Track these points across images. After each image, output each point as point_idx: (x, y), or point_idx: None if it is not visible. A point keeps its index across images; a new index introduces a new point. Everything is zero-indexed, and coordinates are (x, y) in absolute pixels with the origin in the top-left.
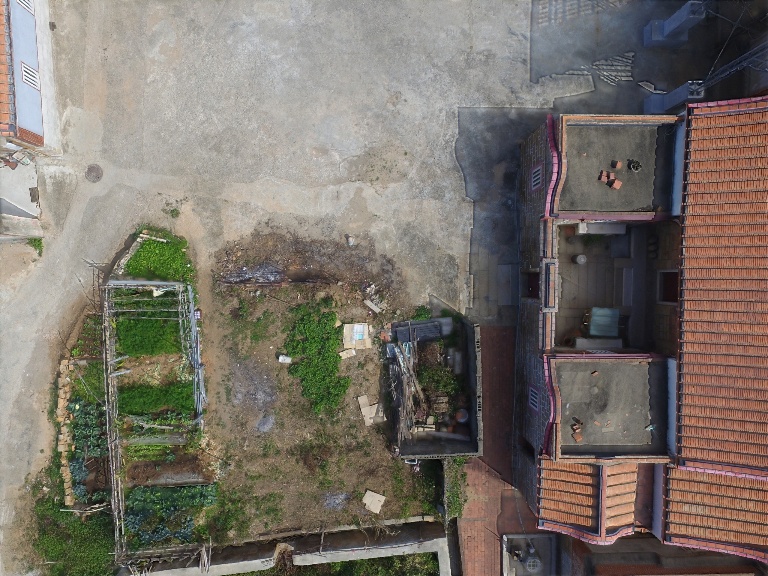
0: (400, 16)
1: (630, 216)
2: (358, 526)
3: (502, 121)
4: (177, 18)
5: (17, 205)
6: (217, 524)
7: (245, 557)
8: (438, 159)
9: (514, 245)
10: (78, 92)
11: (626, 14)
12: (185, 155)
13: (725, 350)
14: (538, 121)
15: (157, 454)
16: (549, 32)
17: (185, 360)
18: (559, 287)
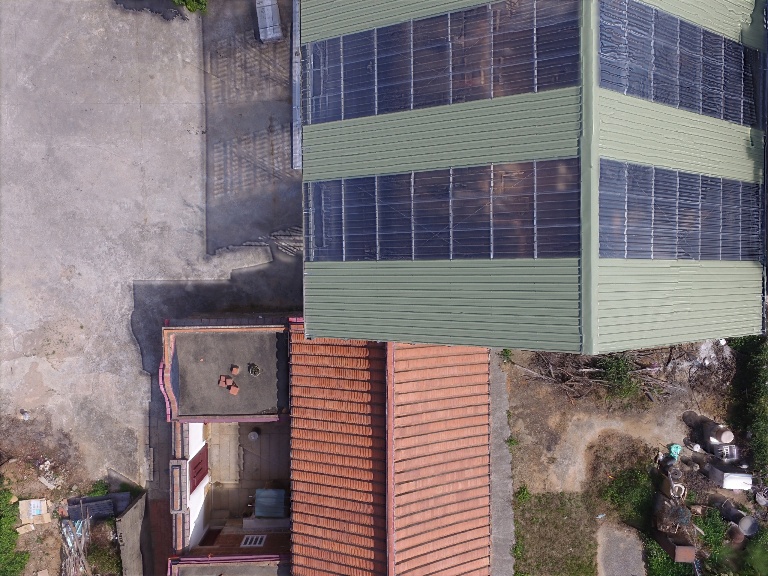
0: (71, 190)
1: (253, 419)
2: None
3: (178, 294)
4: None
5: None
6: None
7: None
8: (114, 332)
9: None
10: None
11: None
12: None
13: (325, 567)
14: (216, 293)
15: None
16: (225, 203)
17: None
18: (241, 459)
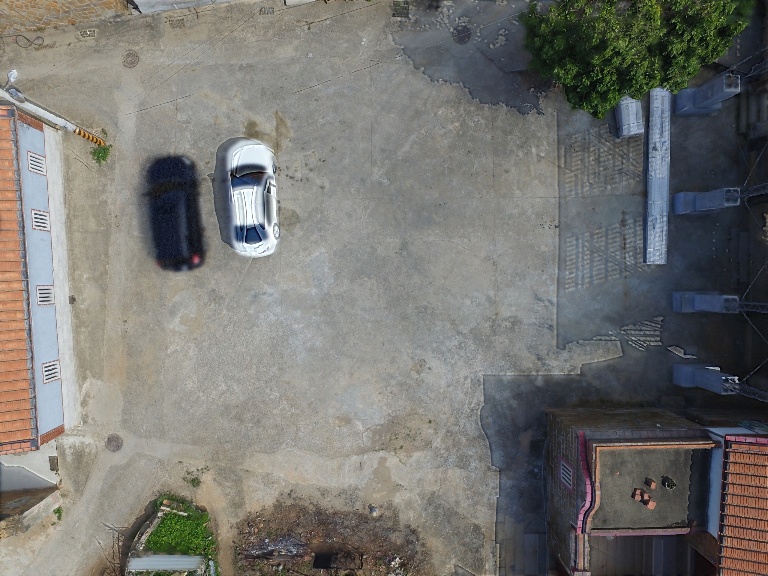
0: (424, 284)
1: (664, 532)
2: None
3: (528, 388)
4: (198, 288)
5: (36, 473)
6: None
7: None
8: (463, 427)
9: (541, 513)
10: (98, 364)
11: (655, 278)
12: (206, 425)
13: None
14: (565, 388)
15: None
16: (576, 297)
17: None
18: None
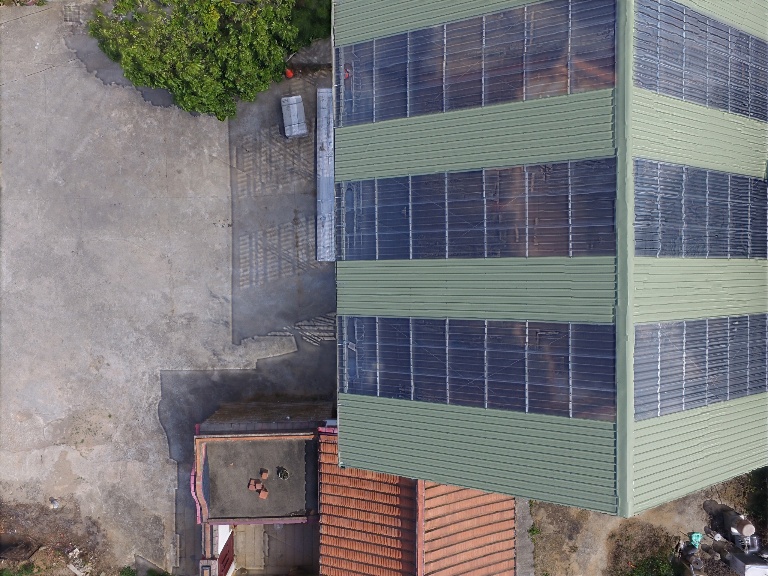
0: (100, 282)
1: (282, 521)
2: None
3: (205, 383)
4: None
5: None
6: None
7: None
8: (142, 421)
9: None
10: None
11: (327, 275)
12: None
13: None
14: (241, 382)
15: None
16: (251, 294)
17: None
18: (266, 545)
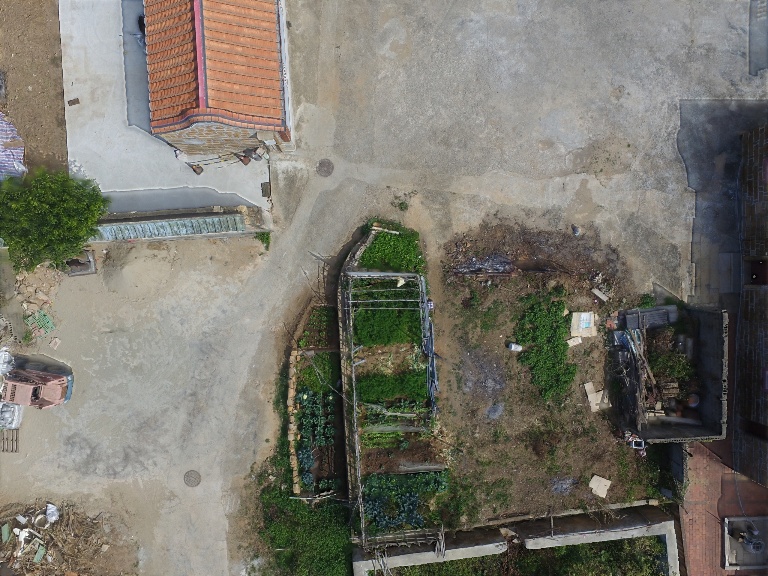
0: (623, 12)
1: None
2: (585, 510)
3: (723, 113)
4: (407, 16)
5: (248, 200)
6: (450, 509)
7: (476, 542)
8: (660, 151)
9: (735, 234)
10: (312, 89)
11: None
12: (414, 149)
13: None
14: (757, 113)
15: (389, 442)
16: (767, 26)
17: (417, 349)
18: None
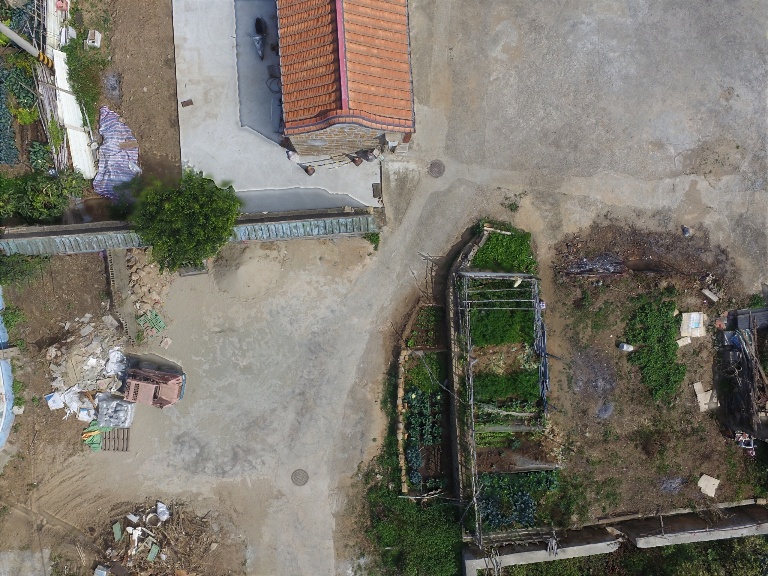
0: (733, 14)
1: None
2: (693, 509)
3: None
4: (519, 18)
5: (359, 200)
6: (561, 508)
7: (586, 540)
8: None
9: None
10: (425, 90)
11: None
12: (525, 150)
13: None
14: None
15: (500, 441)
16: None
17: (528, 349)
18: None
